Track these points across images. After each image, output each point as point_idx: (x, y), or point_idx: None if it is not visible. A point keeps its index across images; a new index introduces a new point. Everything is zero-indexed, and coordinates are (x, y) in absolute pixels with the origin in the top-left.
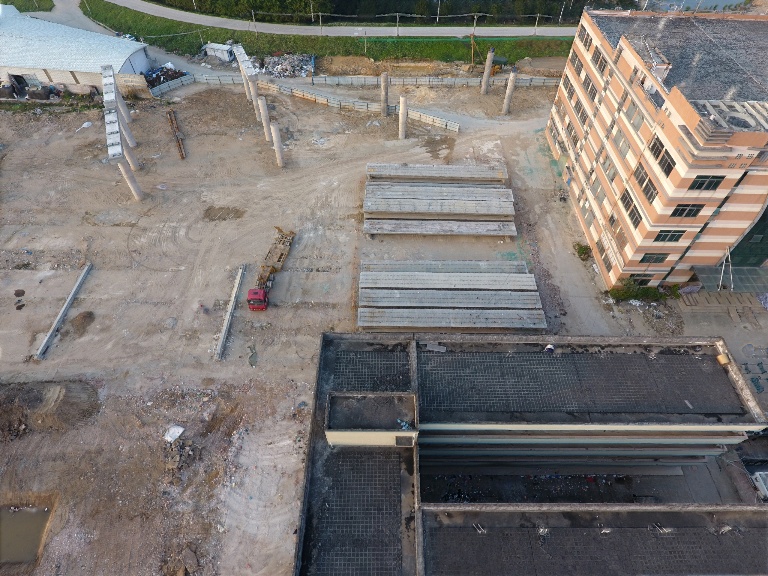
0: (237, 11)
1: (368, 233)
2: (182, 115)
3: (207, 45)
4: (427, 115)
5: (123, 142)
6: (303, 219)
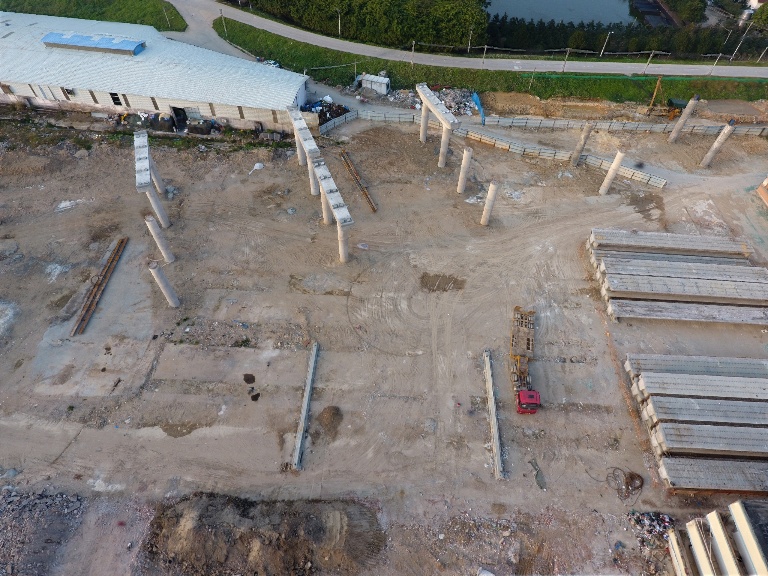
0: (385, 38)
1: (619, 316)
2: (356, 158)
3: (363, 76)
4: (627, 168)
5: None
6: (532, 293)
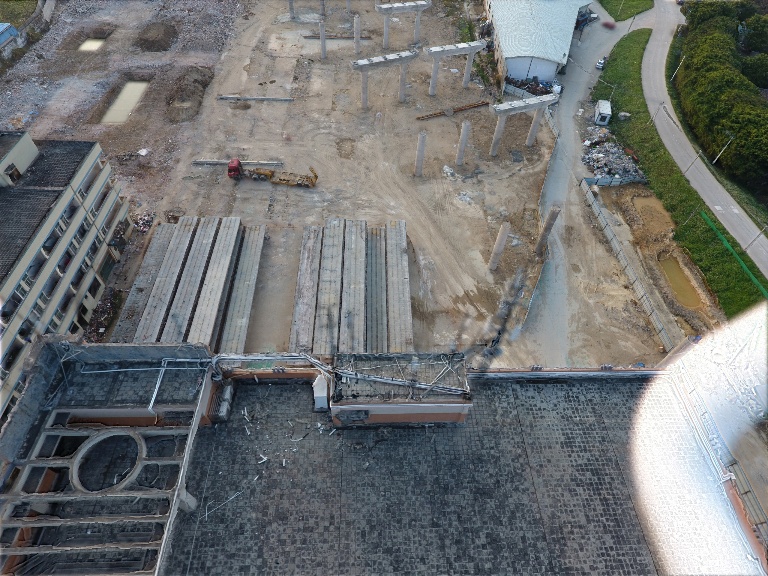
0: None
1: None
2: (483, 110)
3: None
4: None
5: (401, 75)
6: (337, 192)
